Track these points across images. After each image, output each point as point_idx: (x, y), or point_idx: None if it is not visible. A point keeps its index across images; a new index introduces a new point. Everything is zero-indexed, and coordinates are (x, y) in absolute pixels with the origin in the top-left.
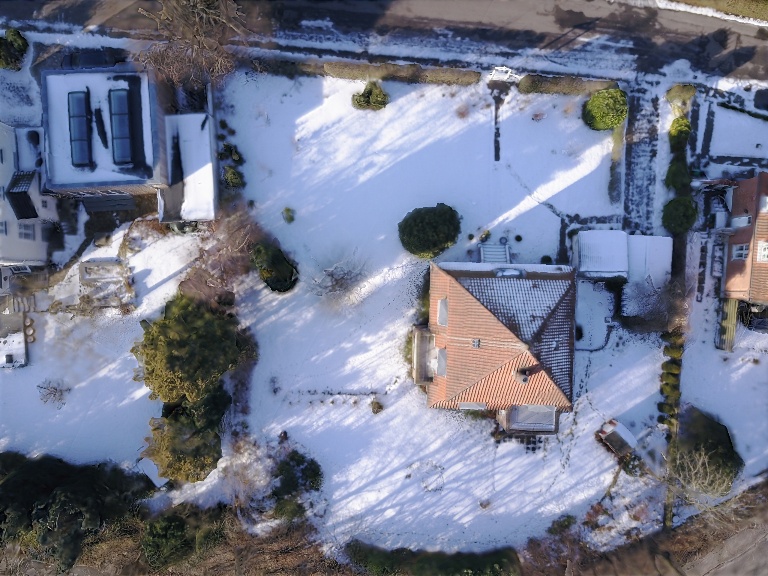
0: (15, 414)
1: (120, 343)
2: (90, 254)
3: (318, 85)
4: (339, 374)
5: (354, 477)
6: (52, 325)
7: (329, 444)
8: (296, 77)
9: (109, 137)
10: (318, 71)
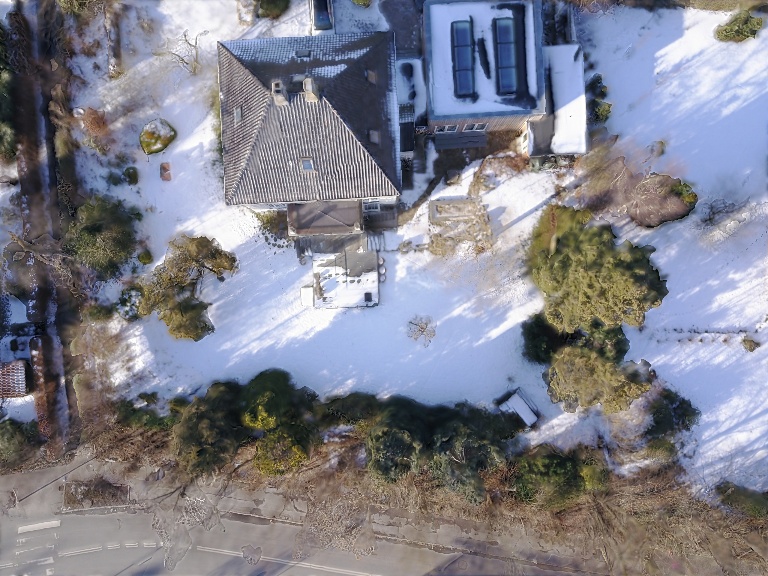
0: (364, 355)
1: (475, 282)
2: (439, 192)
3: (677, 17)
4: (706, 312)
5: (725, 417)
6: (404, 264)
7: (699, 383)
8: (655, 9)
9: (492, 67)
10: (678, 2)
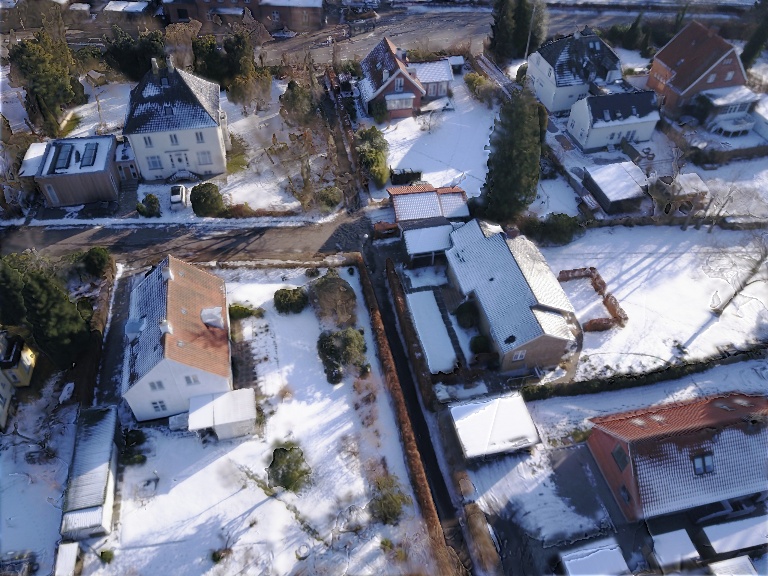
0: None
1: (108, 115)
2: None
3: None
4: None
5: None
6: None
7: (3, 88)
8: None
9: (74, 154)
10: None
